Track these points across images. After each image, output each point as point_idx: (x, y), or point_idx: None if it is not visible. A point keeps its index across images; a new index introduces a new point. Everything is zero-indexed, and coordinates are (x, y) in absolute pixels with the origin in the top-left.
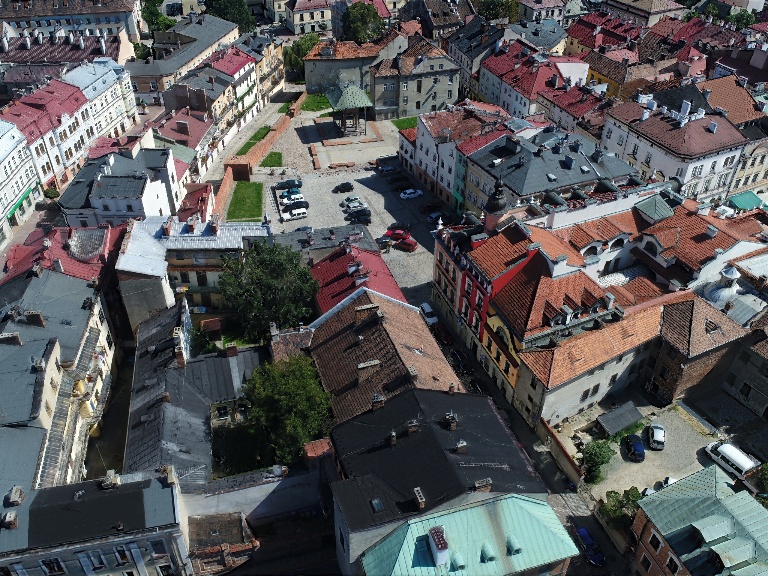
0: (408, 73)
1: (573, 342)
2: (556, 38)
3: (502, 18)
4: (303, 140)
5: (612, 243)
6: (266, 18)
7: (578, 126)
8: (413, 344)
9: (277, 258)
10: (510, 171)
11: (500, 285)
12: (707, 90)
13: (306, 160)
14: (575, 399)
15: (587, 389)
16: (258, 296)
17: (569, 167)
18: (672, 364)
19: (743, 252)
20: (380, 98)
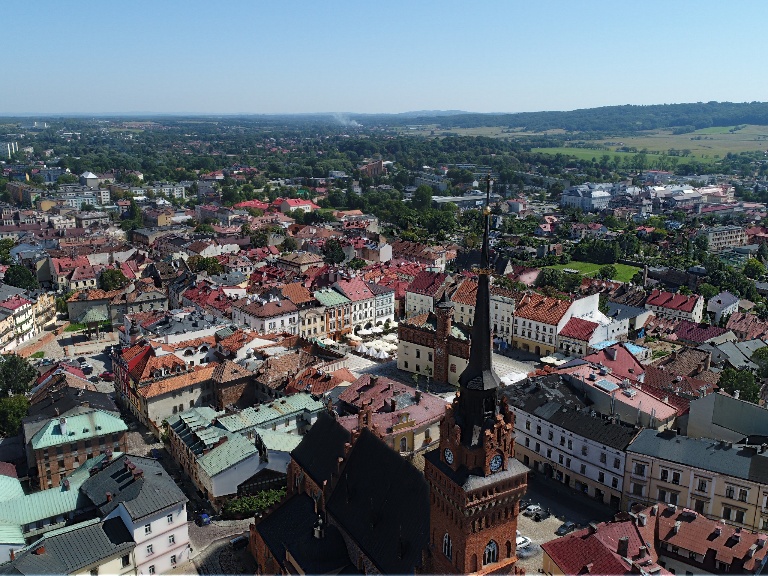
0: (132, 301)
1: (163, 381)
2: (238, 281)
3: (202, 271)
4: (61, 345)
5: (201, 348)
6: (53, 289)
7: (223, 315)
8: (81, 388)
9: None
10: (164, 330)
11: (133, 365)
12: (281, 288)
13: (60, 353)
14: (169, 411)
15: (175, 406)
16: (2, 377)
17: (197, 326)
18: (219, 392)
19: (261, 344)
20: (115, 318)
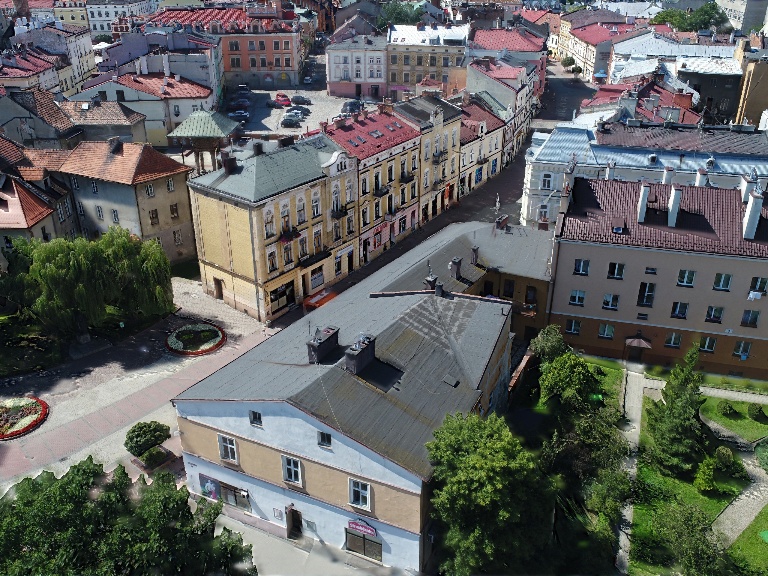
0: None
1: None
2: None
3: None
4: None
5: None
6: None
7: None
8: None
9: (396, 3)
10: None
11: None
12: None
13: None
14: None
15: None
16: None
17: None
18: None
19: None
20: None
